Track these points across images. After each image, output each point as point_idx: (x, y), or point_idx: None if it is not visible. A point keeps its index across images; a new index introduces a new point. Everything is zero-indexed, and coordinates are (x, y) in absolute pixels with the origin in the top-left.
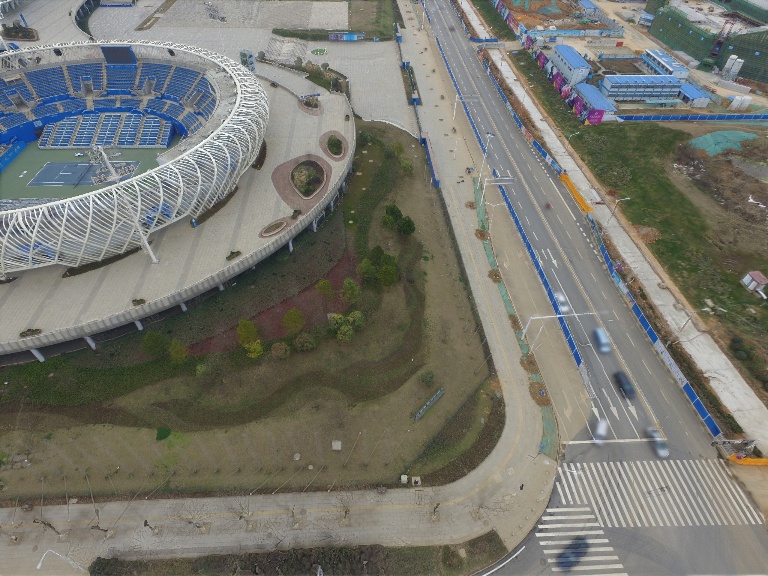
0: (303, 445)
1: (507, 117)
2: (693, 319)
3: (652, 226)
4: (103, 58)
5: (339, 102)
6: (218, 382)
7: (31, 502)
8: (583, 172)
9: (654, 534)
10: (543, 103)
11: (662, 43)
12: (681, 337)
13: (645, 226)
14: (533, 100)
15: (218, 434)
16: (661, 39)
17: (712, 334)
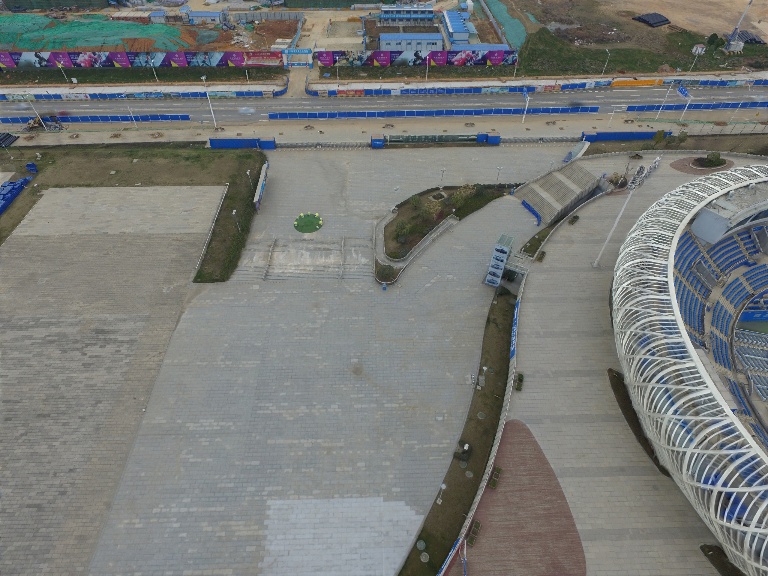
0: None
1: (505, 96)
2: (741, 73)
3: (657, 66)
4: None
5: (596, 164)
6: None
7: None
8: (595, 78)
9: None
10: (468, 76)
11: (325, 8)
12: (759, 78)
13: (658, 68)
14: (461, 80)
15: None
16: (315, 6)
17: (749, 71)
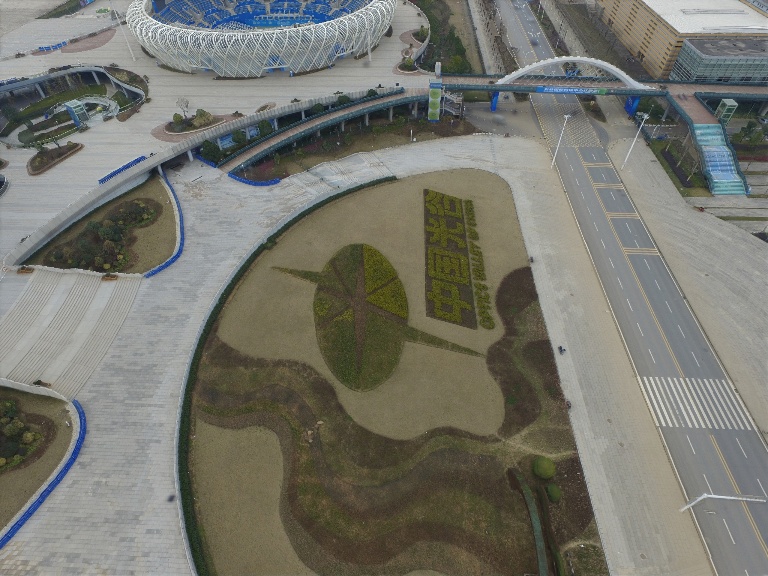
0: (454, 1)
1: None
2: None
3: None
4: (150, 12)
5: None
6: (434, 6)
7: (474, 29)
8: None
9: None
10: None
11: None
12: None
13: None
14: None
15: (452, 8)
16: None
17: None
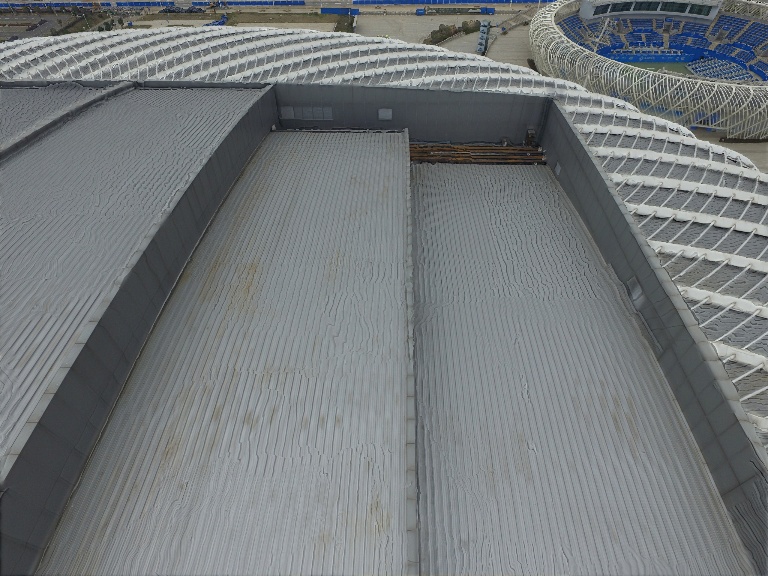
0: None
1: None
2: None
3: None
4: None
5: None
6: None
7: None
8: None
9: (760, 0)
10: None
11: None
12: None
13: None
14: None
15: None
16: None
17: None
